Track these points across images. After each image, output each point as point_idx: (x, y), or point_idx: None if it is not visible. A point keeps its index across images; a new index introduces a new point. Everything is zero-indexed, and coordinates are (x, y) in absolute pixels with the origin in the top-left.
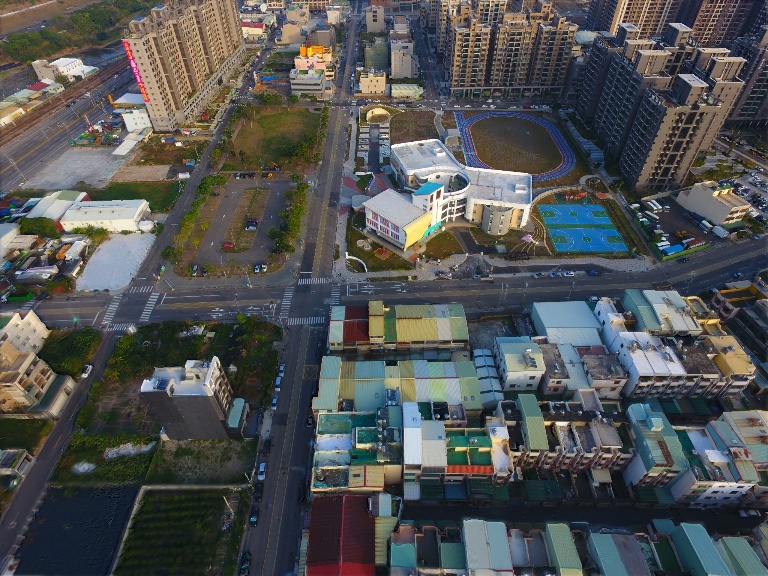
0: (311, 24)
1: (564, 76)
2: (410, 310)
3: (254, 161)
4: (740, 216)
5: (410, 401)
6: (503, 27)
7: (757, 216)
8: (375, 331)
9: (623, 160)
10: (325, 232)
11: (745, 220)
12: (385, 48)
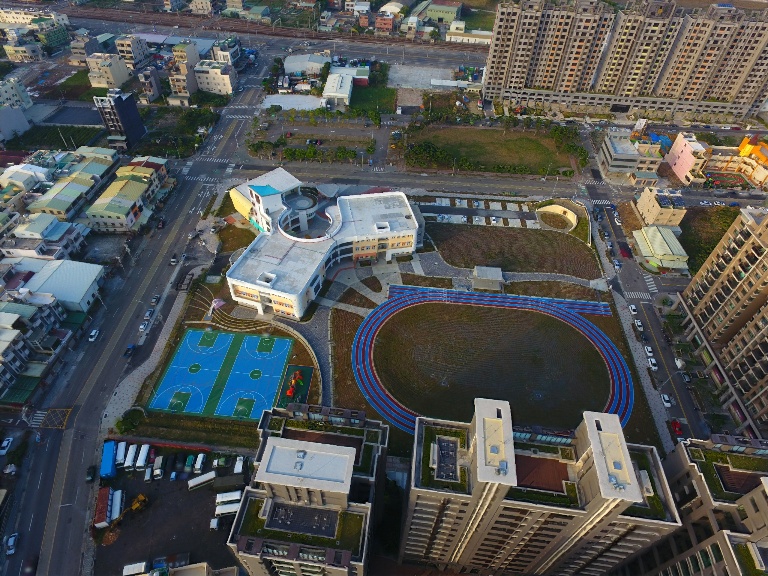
0: None
1: None
2: (135, 188)
3: None
4: None
5: None
6: None
7: None
8: (121, 168)
9: None
10: None
11: None
12: None
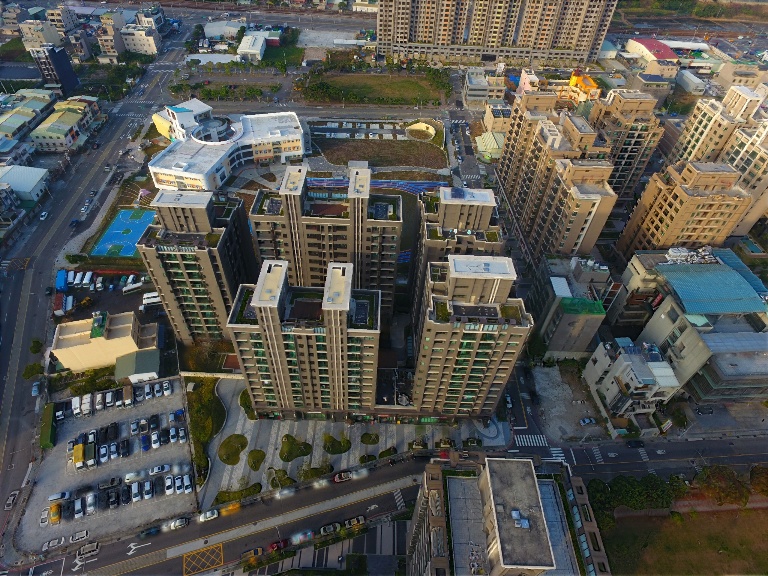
0: None
1: None
2: (71, 117)
3: None
4: None
5: (3, 114)
6: None
7: None
8: (58, 103)
9: None
10: None
11: None
12: None
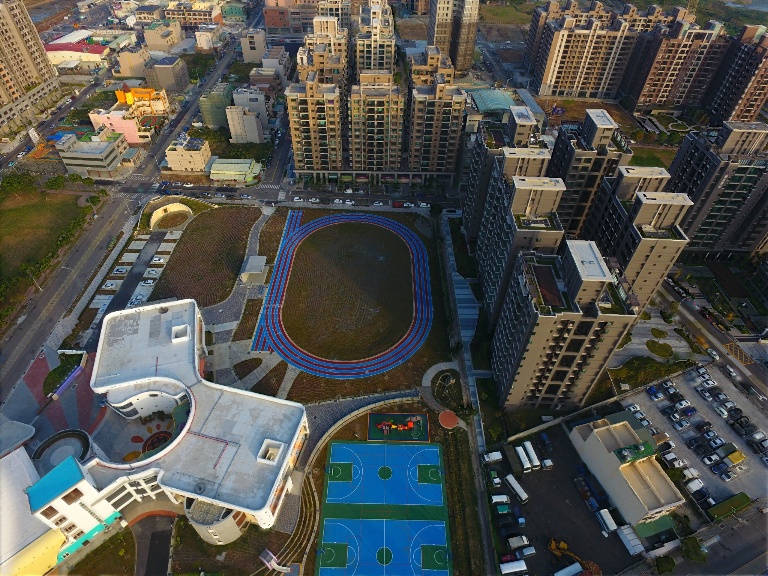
0: (180, 47)
1: (454, 160)
2: None
3: None
4: None
5: None
6: (356, 93)
7: (699, 490)
8: None
9: (495, 345)
10: None
11: None
12: (226, 99)
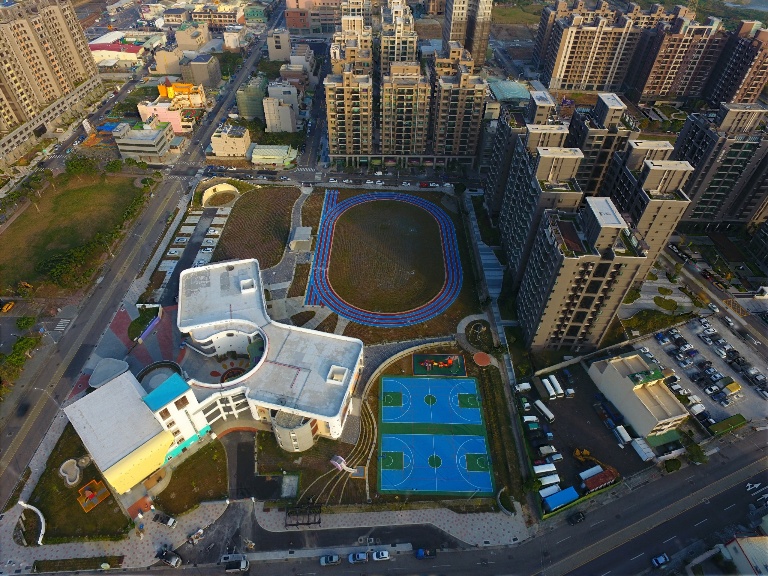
0: (208, 47)
1: (475, 144)
2: None
3: (1, 277)
4: (674, 424)
5: None
6: (388, 82)
7: (702, 413)
8: None
9: (520, 298)
10: (26, 437)
11: (683, 420)
12: (261, 92)
